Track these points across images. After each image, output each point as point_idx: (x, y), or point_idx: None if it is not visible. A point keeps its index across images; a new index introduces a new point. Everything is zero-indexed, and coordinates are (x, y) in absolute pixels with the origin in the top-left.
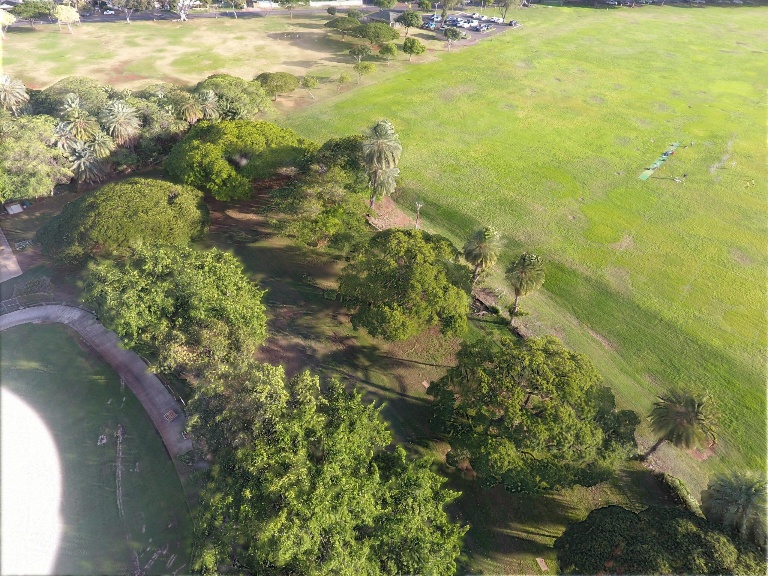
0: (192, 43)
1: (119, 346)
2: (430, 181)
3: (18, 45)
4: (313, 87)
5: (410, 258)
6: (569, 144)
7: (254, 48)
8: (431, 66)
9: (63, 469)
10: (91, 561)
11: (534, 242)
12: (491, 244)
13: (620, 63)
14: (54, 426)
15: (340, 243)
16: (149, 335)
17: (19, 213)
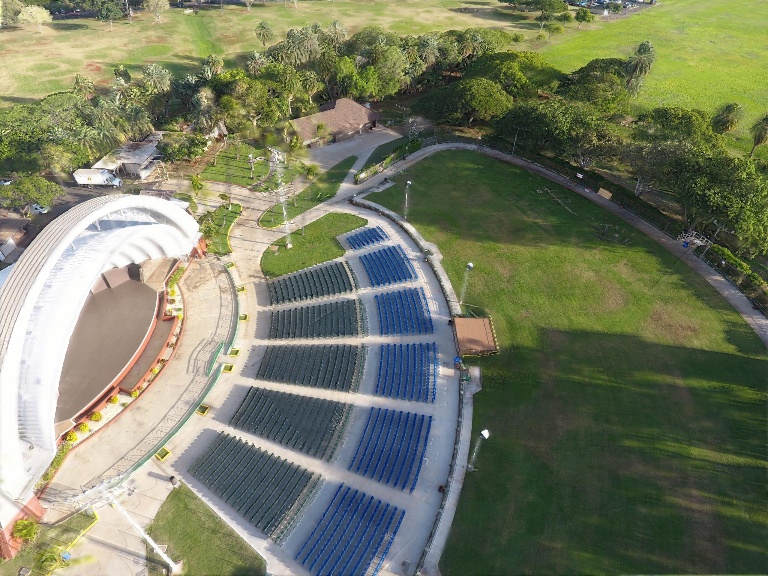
0: (394, 15)
1: (514, 159)
2: (643, 100)
3: (264, 15)
4: (514, 44)
5: (686, 119)
6: (741, 82)
7: (445, 18)
8: (598, 32)
9: (527, 200)
10: (574, 227)
11: (740, 133)
12: (738, 113)
13: (763, 31)
14: (506, 186)
15: (618, 120)
16: (575, 132)
17: None
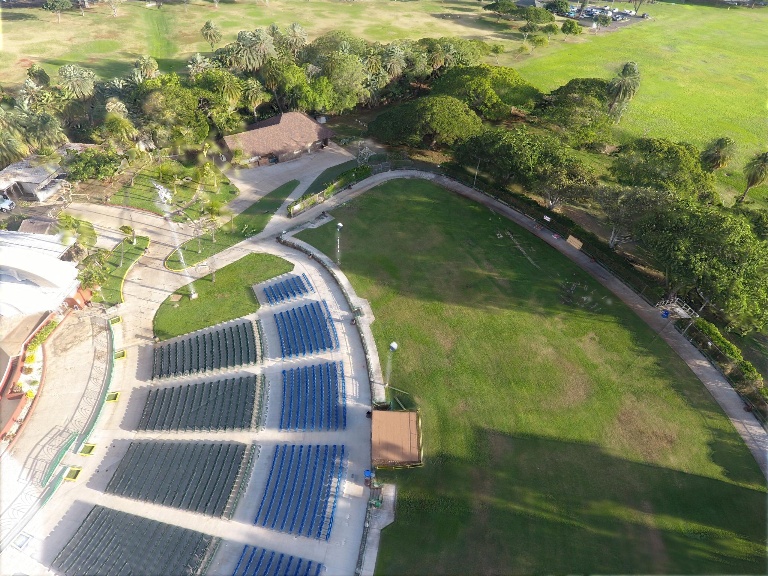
0: (371, 18)
1: (475, 193)
2: (628, 124)
3: (232, 12)
4: (494, 55)
5: (672, 153)
6: (734, 108)
7: (425, 24)
8: (585, 46)
9: (484, 247)
10: (535, 285)
11: (732, 168)
12: (730, 149)
13: (757, 52)
14: (462, 228)
15: (597, 149)
16: (542, 168)
17: (324, 124)
